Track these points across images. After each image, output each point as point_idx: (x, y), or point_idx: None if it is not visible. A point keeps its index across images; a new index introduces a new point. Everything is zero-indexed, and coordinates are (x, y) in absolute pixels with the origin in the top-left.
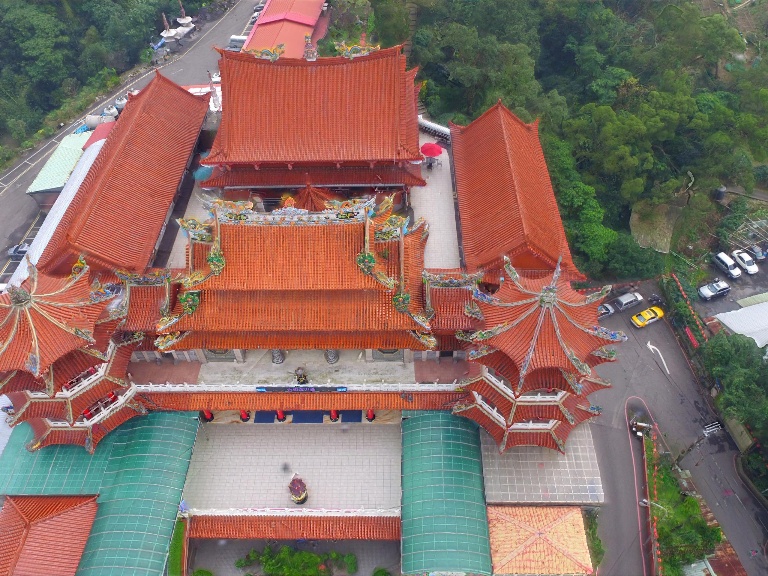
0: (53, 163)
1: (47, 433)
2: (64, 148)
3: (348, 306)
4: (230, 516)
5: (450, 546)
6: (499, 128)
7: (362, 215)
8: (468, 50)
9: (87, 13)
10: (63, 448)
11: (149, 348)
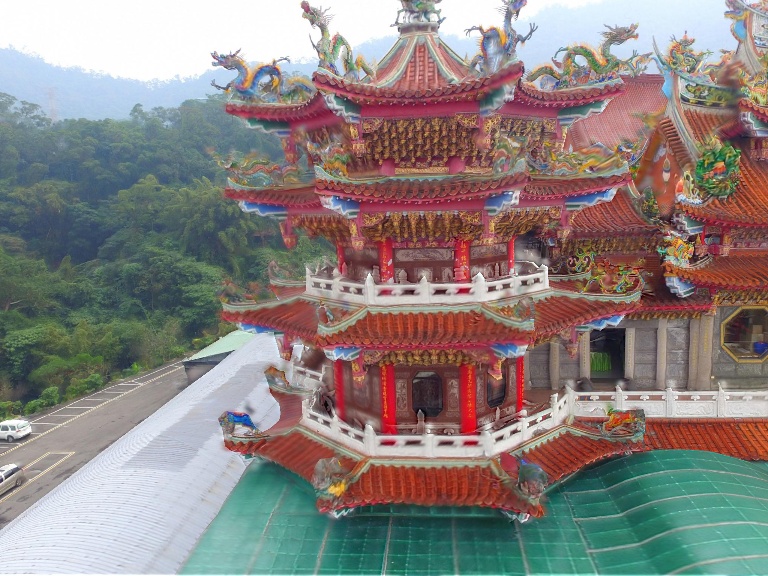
0: (220, 343)
1: (359, 469)
2: (233, 335)
3: None
4: None
5: None
6: None
7: None
8: None
9: (253, 275)
10: (405, 525)
11: None
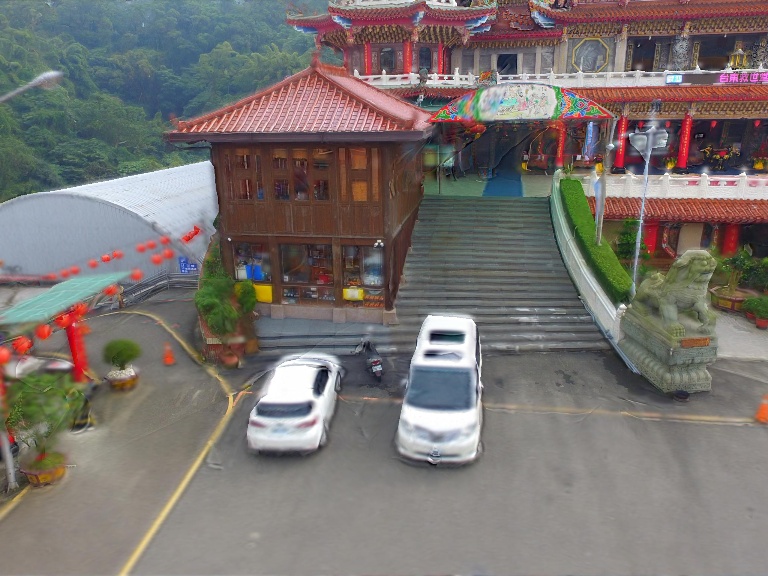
0: None
1: None
2: None
3: None
4: (658, 198)
5: None
6: None
7: None
8: None
9: None
10: None
11: None
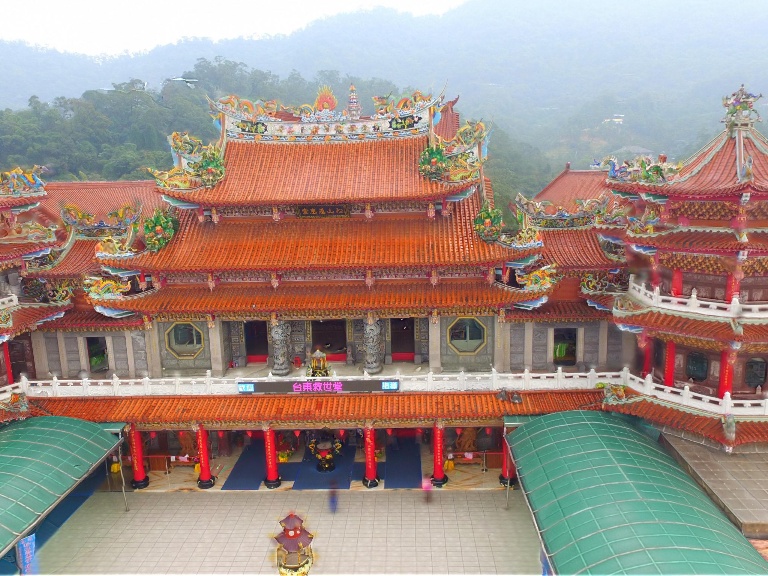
0: None
1: None
2: None
3: (404, 241)
4: None
5: (701, 569)
6: (574, 176)
7: (425, 122)
8: (511, 223)
9: None
10: None
11: (73, 320)
